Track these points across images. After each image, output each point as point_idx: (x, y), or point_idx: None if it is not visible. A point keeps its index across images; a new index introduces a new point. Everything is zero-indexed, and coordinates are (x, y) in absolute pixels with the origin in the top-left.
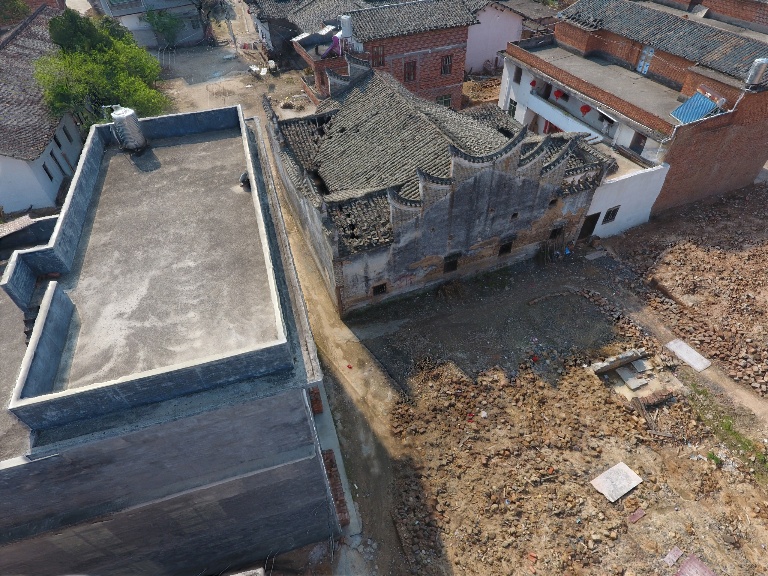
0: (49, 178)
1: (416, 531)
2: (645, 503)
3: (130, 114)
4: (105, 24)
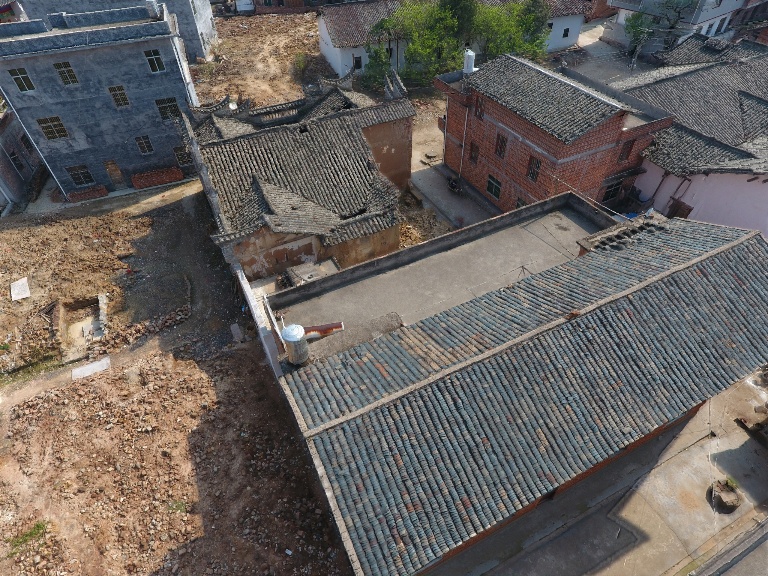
0: (355, 66)
1: (48, 217)
2: (1, 299)
3: (147, 1)
4: (528, 1)
